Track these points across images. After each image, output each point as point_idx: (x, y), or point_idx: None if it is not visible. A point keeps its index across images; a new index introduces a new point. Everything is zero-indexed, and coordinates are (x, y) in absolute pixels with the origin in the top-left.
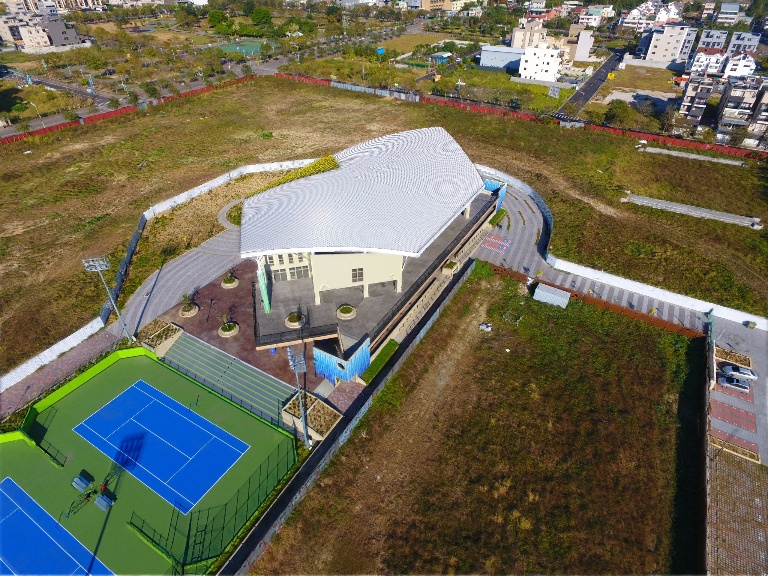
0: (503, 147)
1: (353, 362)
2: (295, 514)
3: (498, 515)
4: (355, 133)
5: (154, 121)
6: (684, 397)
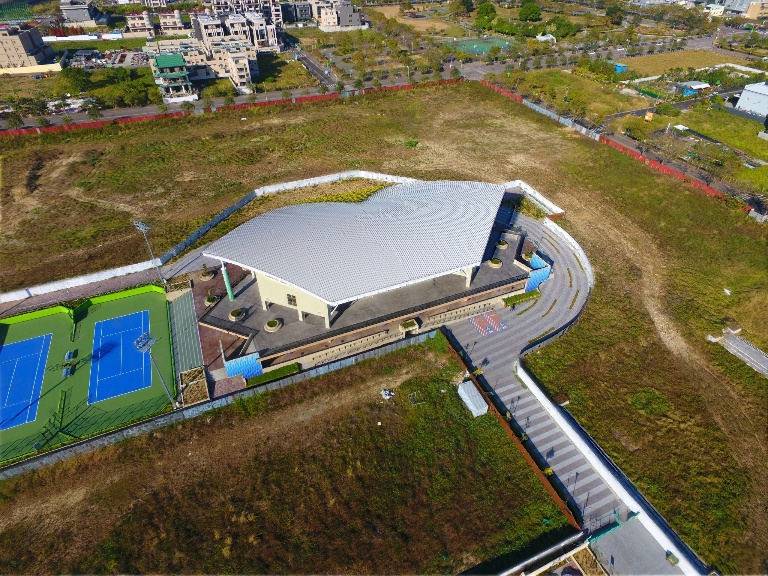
0: (633, 221)
1: (234, 365)
2: (124, 442)
3: (218, 532)
4: (490, 161)
5: (343, 110)
6: (481, 568)
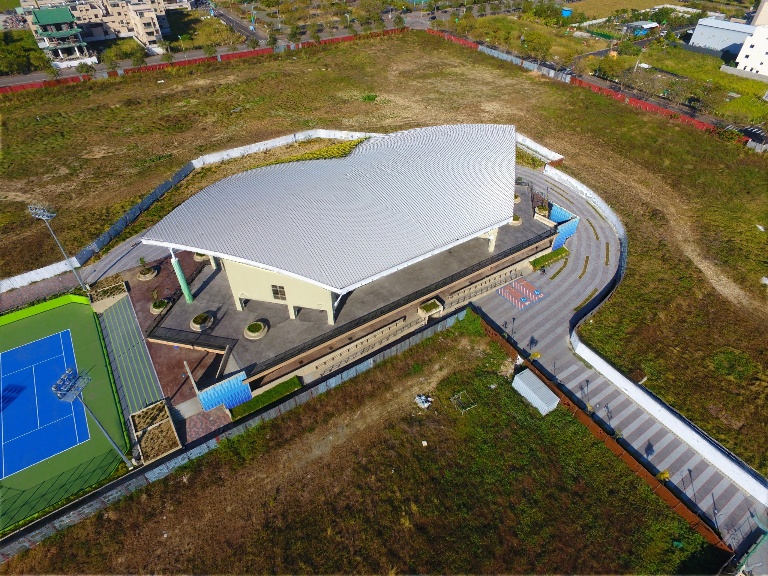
0: (636, 162)
1: (211, 393)
2: (58, 536)
3: None
4: (463, 111)
5: (280, 66)
6: None
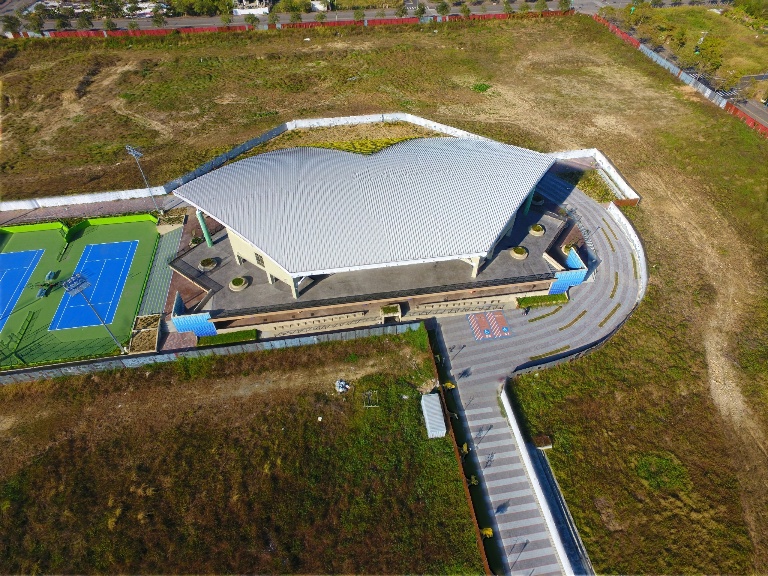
0: (732, 223)
1: (182, 321)
2: (63, 378)
3: (112, 500)
4: (569, 120)
5: (417, 38)
6: None
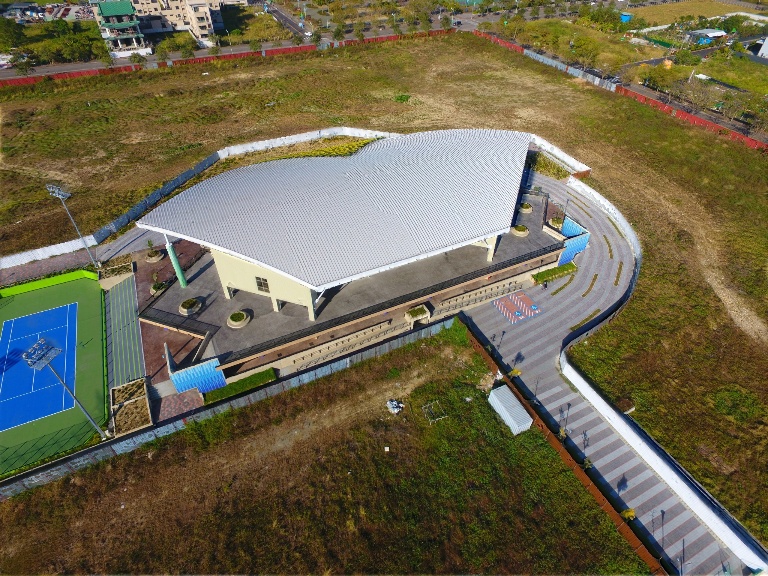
0: (671, 179)
1: (184, 376)
2: (26, 494)
3: None
4: (495, 115)
5: (321, 63)
6: None
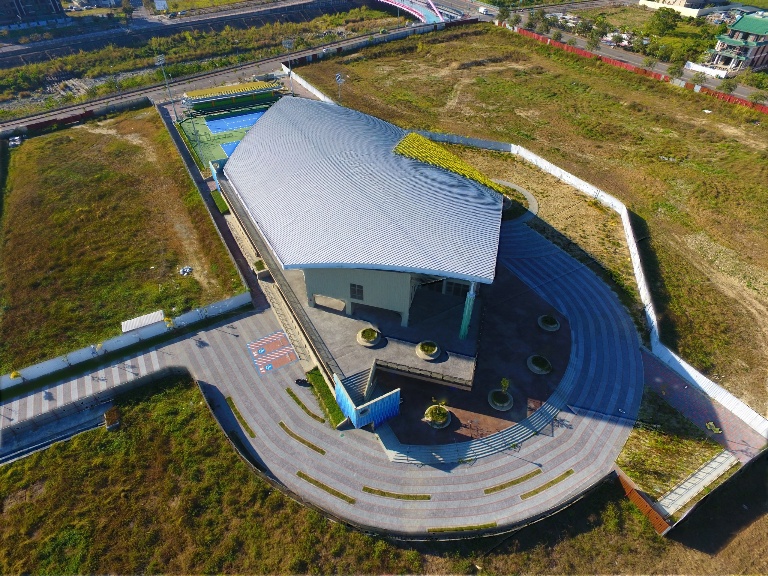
0: None
1: None
2: None
3: (95, 204)
4: None
5: None
6: None
